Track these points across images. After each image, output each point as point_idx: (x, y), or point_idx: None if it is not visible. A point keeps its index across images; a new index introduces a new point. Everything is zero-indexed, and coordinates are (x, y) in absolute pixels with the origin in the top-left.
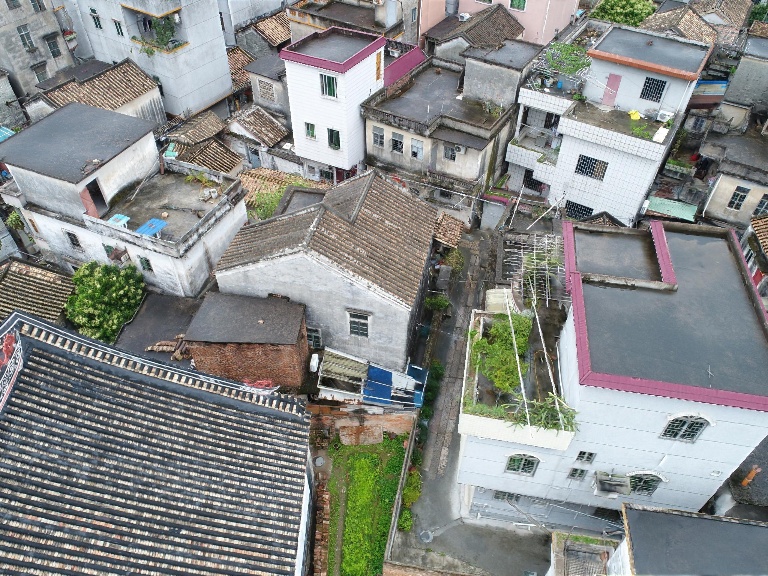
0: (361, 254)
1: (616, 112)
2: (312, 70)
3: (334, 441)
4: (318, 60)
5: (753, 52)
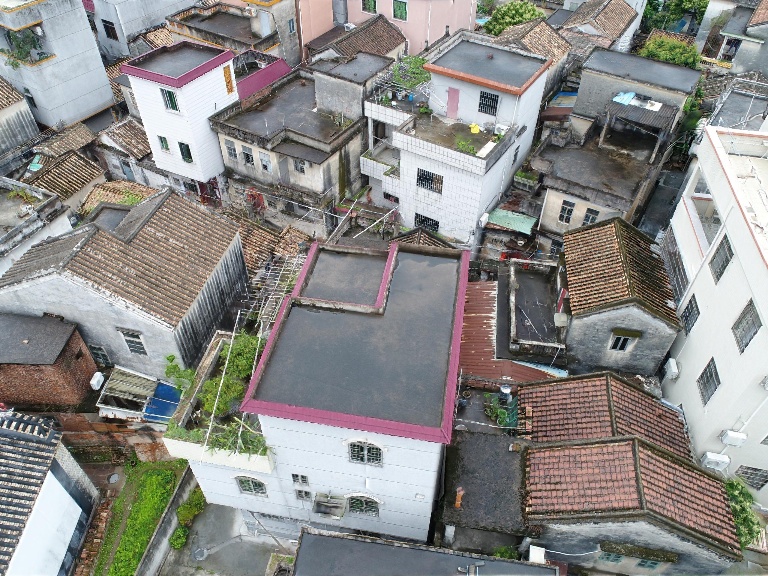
0: (128, 274)
1: (458, 125)
2: (153, 84)
3: (132, 458)
4: (155, 75)
5: (593, 65)
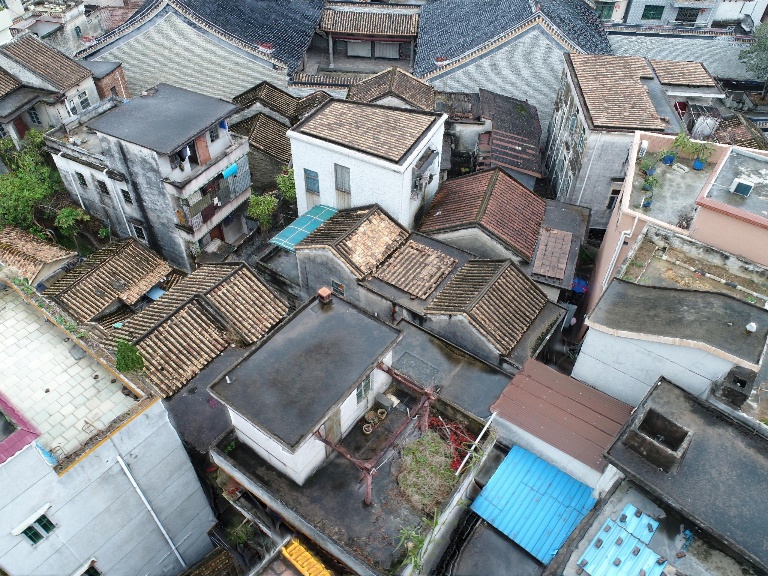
0: None
1: None
2: None
3: None
4: None
5: None
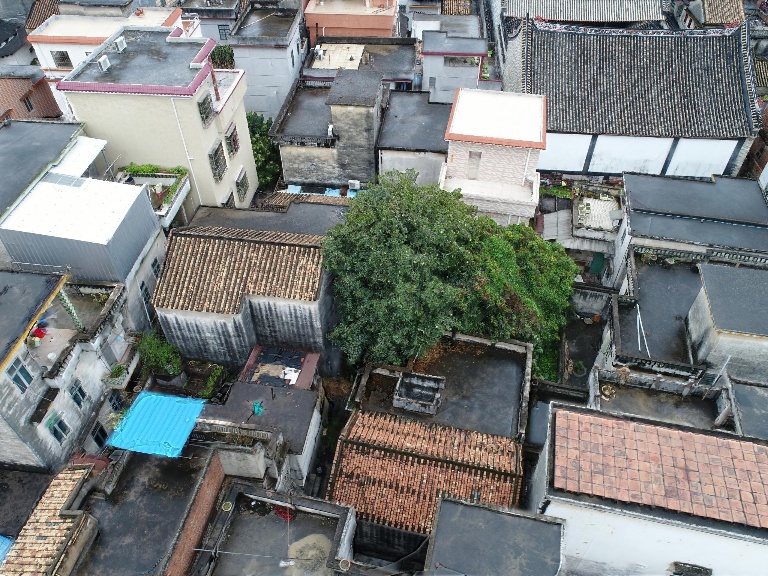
0: None
1: None
2: None
3: None
4: None
5: None
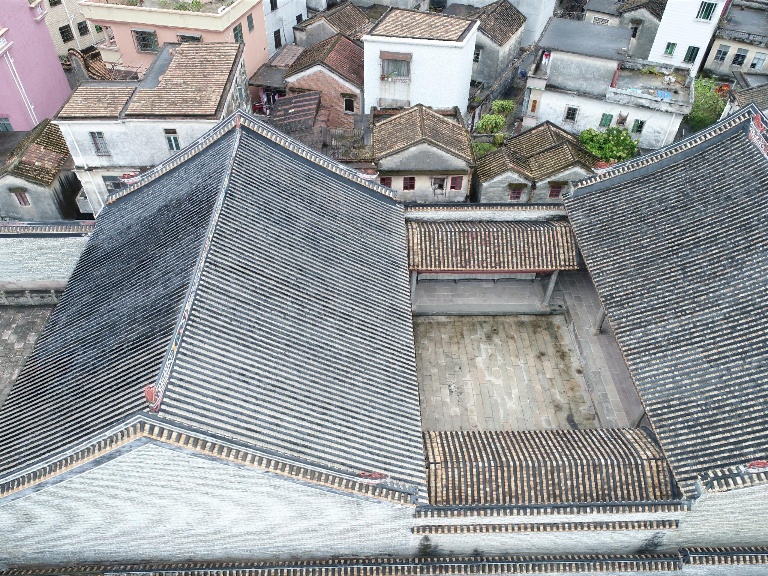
0: None
1: None
2: None
3: None
4: None
5: None
